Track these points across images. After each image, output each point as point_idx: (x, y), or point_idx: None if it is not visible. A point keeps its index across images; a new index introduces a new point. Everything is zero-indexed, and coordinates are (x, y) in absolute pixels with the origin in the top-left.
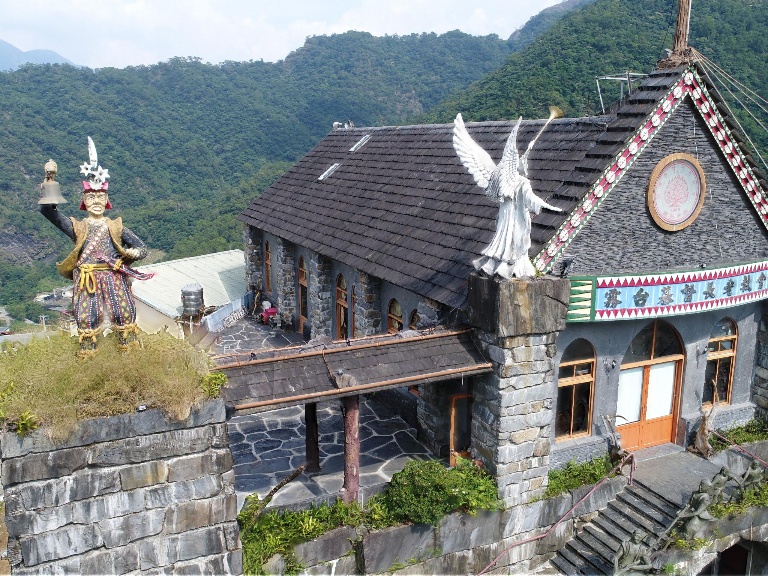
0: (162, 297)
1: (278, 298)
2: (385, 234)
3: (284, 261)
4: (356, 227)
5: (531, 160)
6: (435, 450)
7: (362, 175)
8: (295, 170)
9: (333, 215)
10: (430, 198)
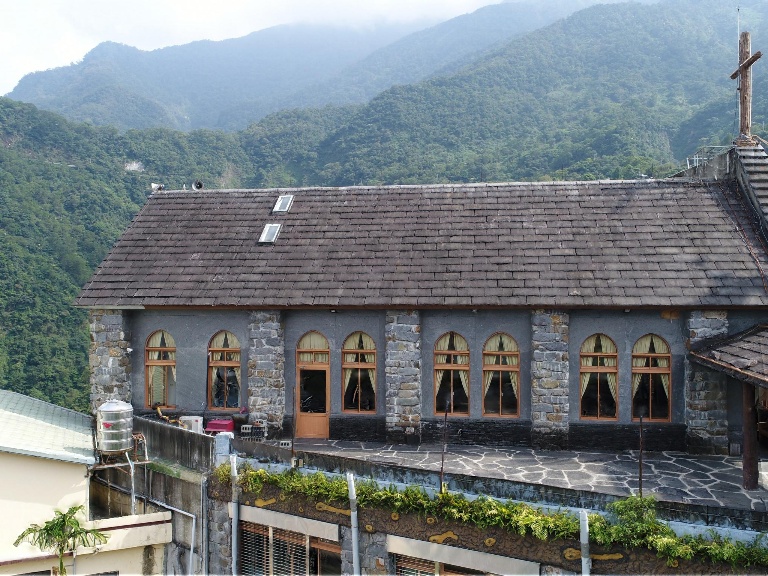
0: (16, 440)
1: (253, 398)
2: (560, 273)
3: (279, 342)
4: (485, 274)
5: (654, 207)
6: (733, 451)
7: (369, 232)
8: (148, 237)
9: (400, 270)
10: (569, 240)
